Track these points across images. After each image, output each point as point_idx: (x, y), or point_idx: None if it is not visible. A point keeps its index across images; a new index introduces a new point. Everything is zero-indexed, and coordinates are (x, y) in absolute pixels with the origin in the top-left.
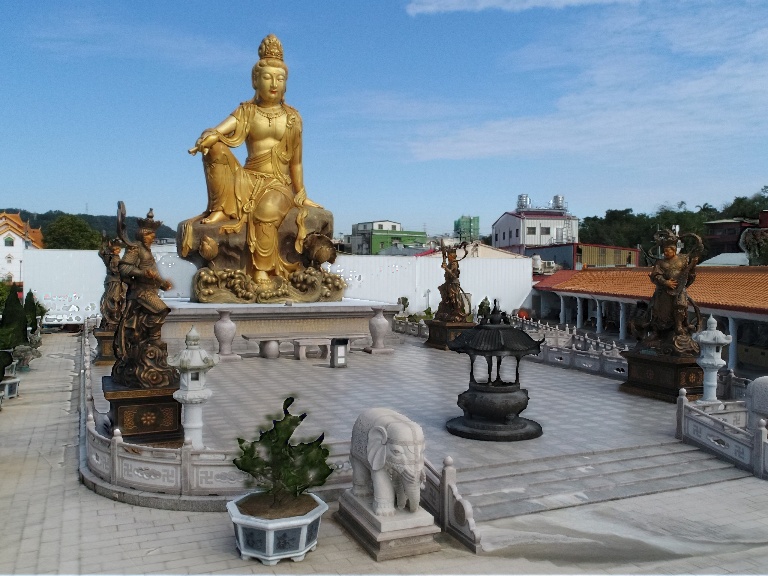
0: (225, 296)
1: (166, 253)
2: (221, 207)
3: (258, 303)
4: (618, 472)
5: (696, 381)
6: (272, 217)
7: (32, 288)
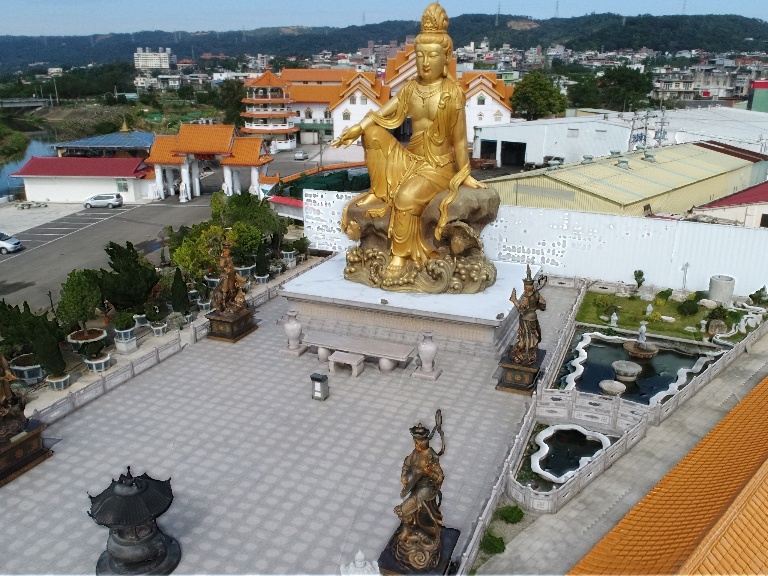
0: (361, 276)
1: None
2: (373, 190)
3: (381, 289)
4: None
5: None
6: (406, 206)
7: None
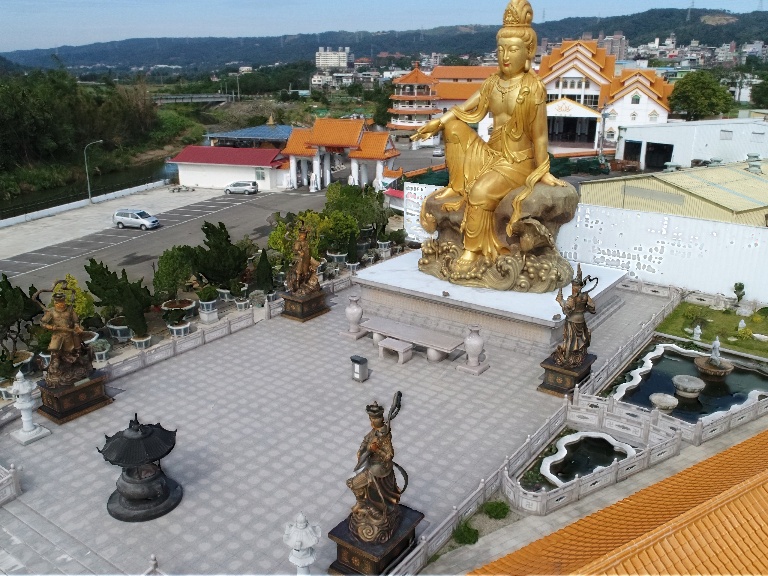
0: (433, 268)
1: None
2: (451, 184)
3: (449, 282)
4: (64, 573)
5: (361, 567)
6: (478, 201)
7: None
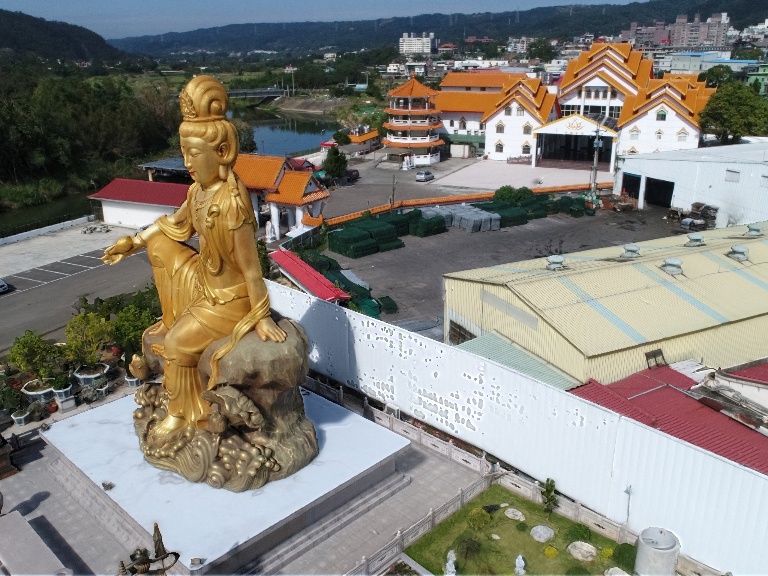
0: (142, 427)
1: (316, 299)
2: None
3: None
4: None
5: None
6: (169, 354)
7: (576, 200)
